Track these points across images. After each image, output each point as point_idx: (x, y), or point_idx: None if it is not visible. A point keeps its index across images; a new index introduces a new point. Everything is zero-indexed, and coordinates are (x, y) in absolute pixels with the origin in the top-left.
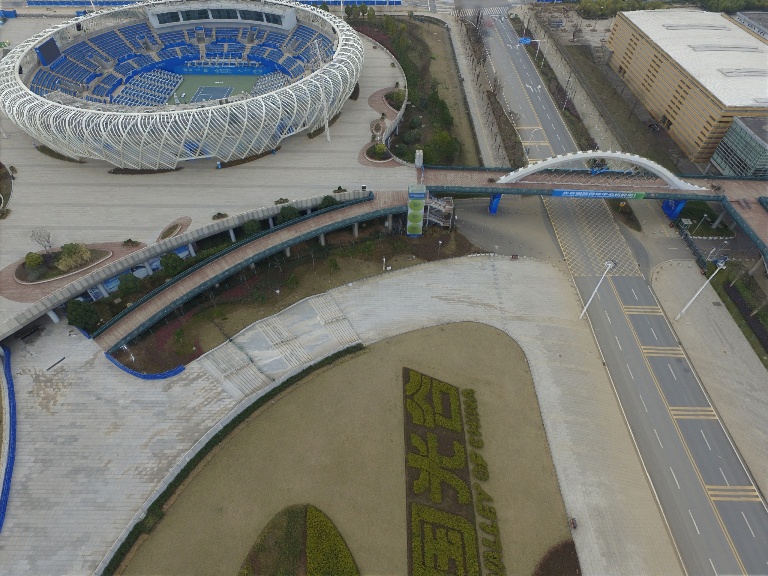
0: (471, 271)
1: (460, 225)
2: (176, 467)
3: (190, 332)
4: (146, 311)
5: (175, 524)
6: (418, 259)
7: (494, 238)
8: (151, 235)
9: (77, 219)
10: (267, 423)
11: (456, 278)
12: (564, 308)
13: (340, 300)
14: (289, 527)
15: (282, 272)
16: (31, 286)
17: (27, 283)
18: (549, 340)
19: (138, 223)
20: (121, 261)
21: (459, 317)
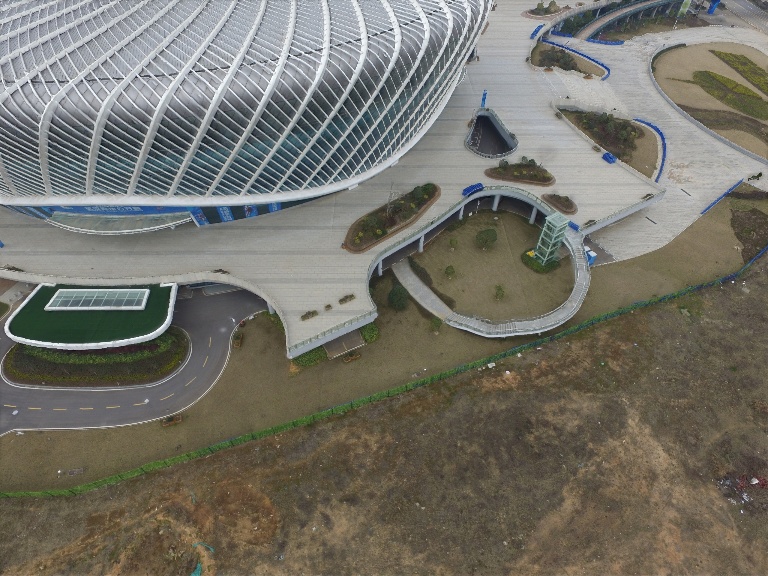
0: (714, 30)
1: (698, 17)
2: (652, 57)
3: (611, 37)
4: (588, 30)
5: (661, 71)
6: (686, 26)
7: (718, 21)
8: (572, 6)
9: (530, 2)
10: (668, 57)
11: (709, 32)
12: (766, 40)
13: (661, 36)
14: (702, 73)
15: (631, 25)
16: (541, 17)
17: (540, 16)
18: (765, 47)
19: (560, 3)
20: (572, 11)
21: (720, 41)
